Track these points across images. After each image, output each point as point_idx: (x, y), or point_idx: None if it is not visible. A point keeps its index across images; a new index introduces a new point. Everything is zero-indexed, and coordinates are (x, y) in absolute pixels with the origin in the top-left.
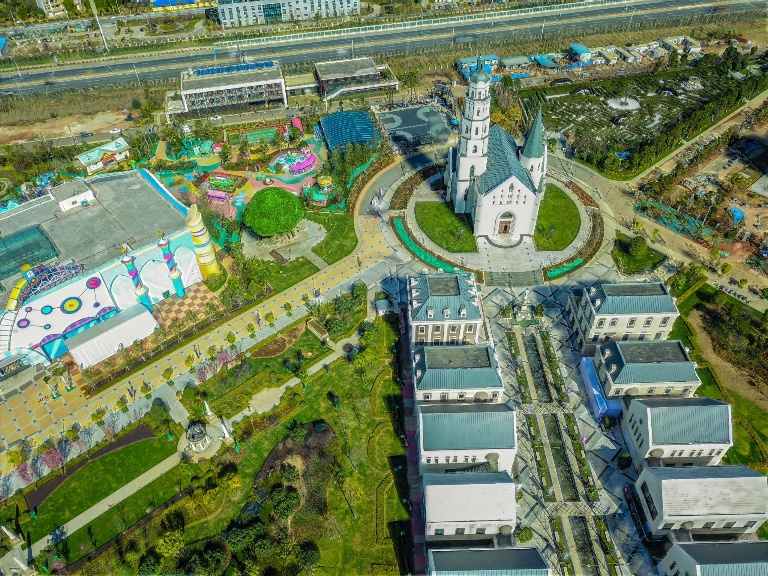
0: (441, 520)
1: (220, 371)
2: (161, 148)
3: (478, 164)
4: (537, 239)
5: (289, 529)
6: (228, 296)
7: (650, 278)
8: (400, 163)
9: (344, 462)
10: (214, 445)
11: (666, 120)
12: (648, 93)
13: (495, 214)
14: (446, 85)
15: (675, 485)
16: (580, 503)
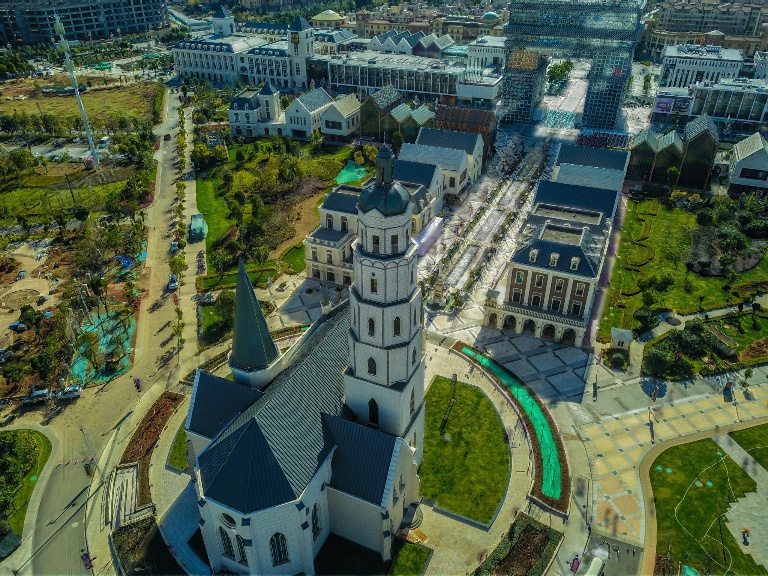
0: None
1: None
2: None
3: None
4: None
5: None
6: None
7: None
8: None
9: (677, 253)
10: None
11: None
12: None
13: None
14: None
15: None
16: (495, 208)
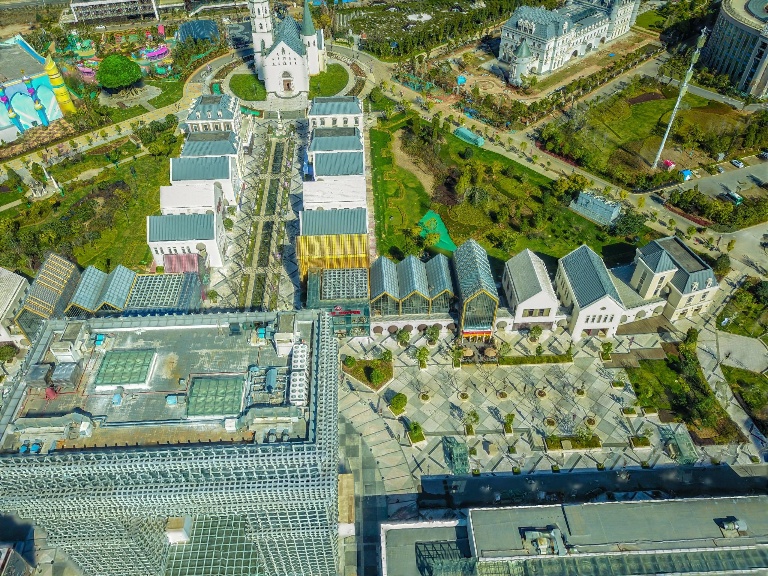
0: (169, 207)
1: (62, 161)
2: (53, 46)
3: (266, 39)
4: (311, 93)
5: (86, 228)
6: (76, 121)
7: (380, 114)
8: (233, 54)
9: (131, 201)
10: (49, 194)
11: (445, 27)
12: (442, 11)
13: (277, 74)
14: (289, 6)
15: (311, 185)
16: (274, 216)
